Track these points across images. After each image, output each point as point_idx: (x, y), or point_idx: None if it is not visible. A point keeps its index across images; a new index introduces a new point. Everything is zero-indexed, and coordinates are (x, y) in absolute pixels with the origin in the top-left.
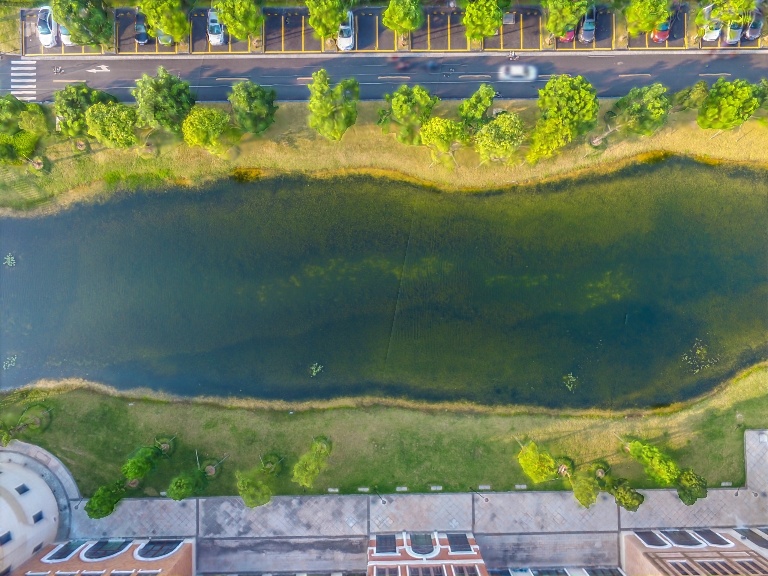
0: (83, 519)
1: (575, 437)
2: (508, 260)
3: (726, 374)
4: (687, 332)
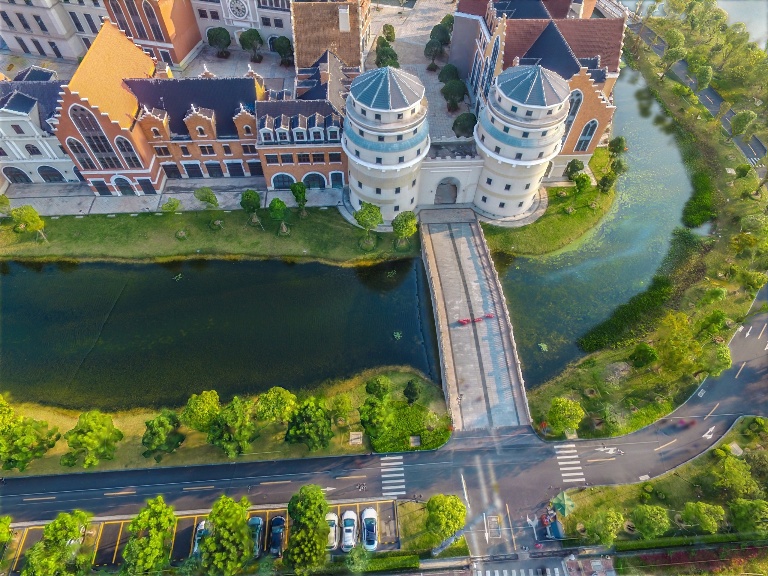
0: (335, 197)
1: (6, 244)
2: (4, 353)
3: None
4: None
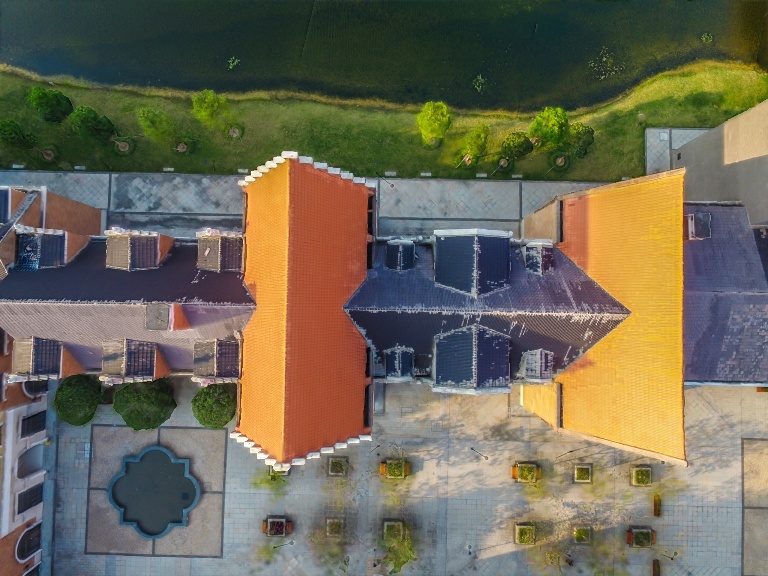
0: None
1: None
2: None
3: (631, 82)
4: (594, 41)
